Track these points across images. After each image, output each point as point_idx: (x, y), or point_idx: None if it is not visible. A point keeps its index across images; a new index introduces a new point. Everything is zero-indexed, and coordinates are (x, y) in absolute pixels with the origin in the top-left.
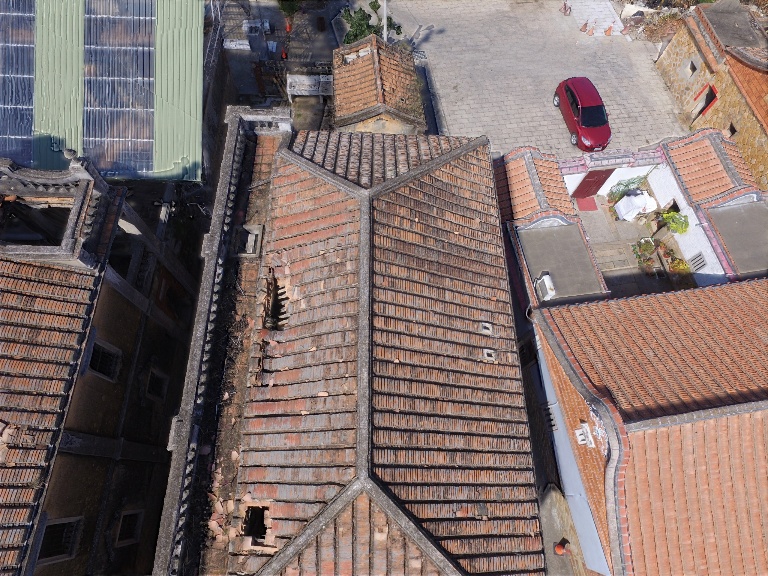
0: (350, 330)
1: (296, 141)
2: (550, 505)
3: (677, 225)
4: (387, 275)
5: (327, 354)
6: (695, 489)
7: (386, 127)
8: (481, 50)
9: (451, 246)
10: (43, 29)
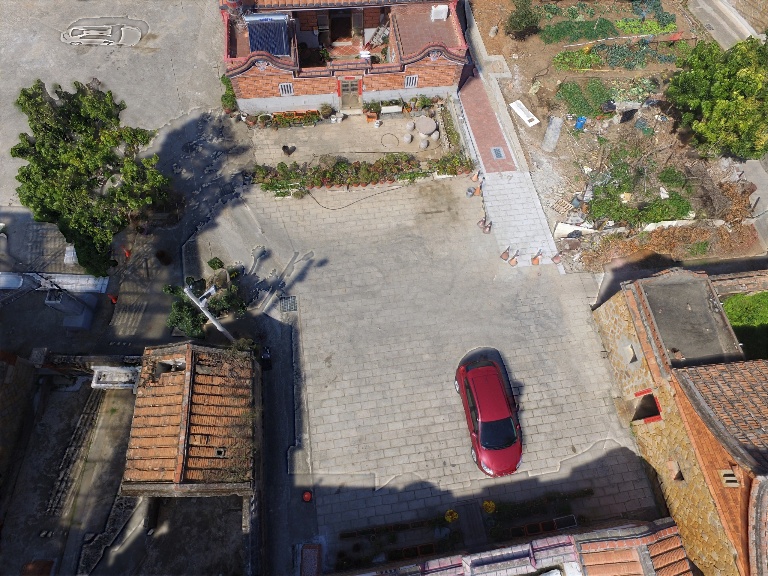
0: None
1: None
2: None
3: None
4: None
5: None
6: None
7: None
8: (370, 293)
9: None
10: None
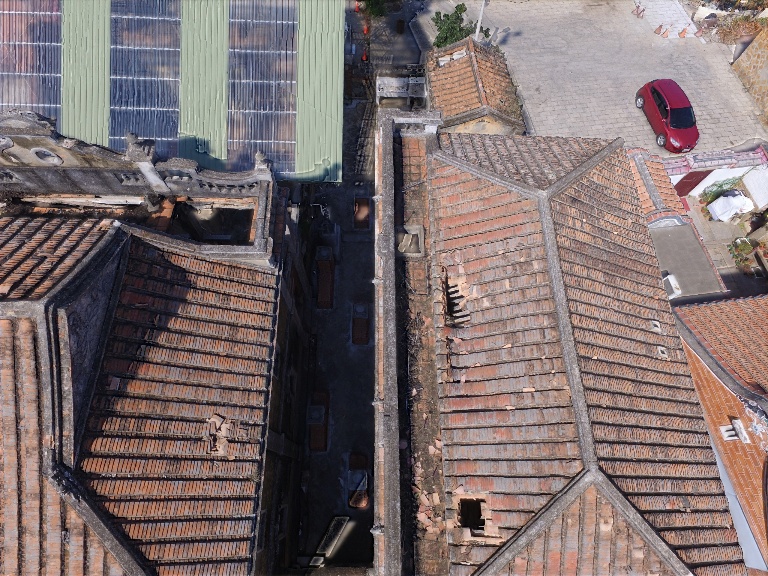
0: (549, 327)
1: (442, 143)
2: None
3: None
4: (572, 274)
5: (527, 351)
6: None
7: (486, 129)
8: (559, 52)
9: (614, 246)
10: (188, 33)
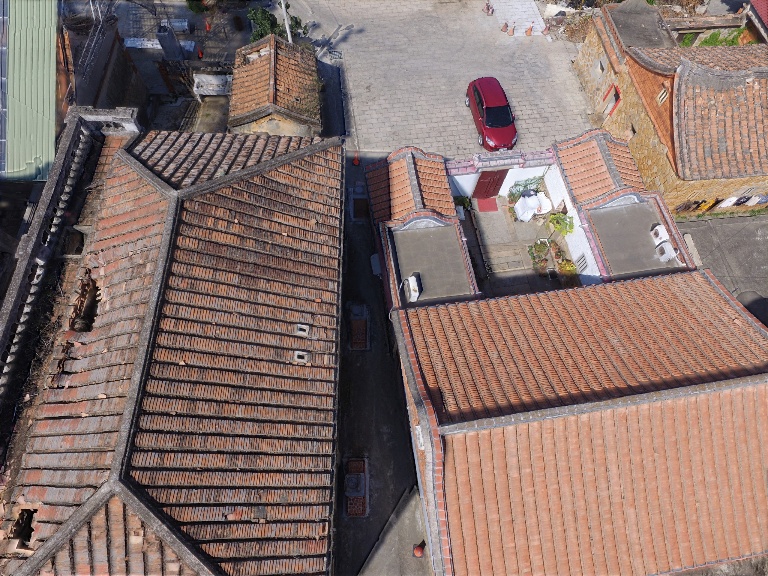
0: (136, 332)
1: (141, 141)
2: (414, 507)
3: (561, 226)
4: (188, 277)
5: (113, 356)
6: (519, 492)
7: (281, 127)
8: (398, 50)
9: (274, 247)
10: None
